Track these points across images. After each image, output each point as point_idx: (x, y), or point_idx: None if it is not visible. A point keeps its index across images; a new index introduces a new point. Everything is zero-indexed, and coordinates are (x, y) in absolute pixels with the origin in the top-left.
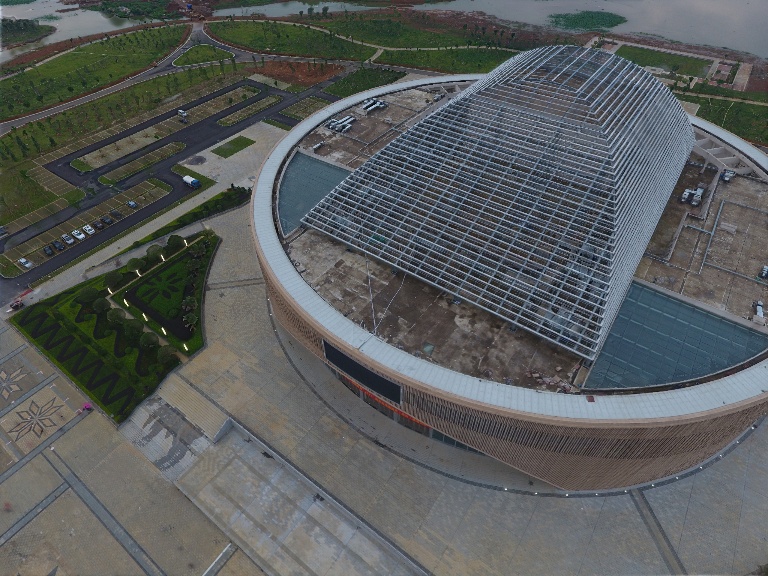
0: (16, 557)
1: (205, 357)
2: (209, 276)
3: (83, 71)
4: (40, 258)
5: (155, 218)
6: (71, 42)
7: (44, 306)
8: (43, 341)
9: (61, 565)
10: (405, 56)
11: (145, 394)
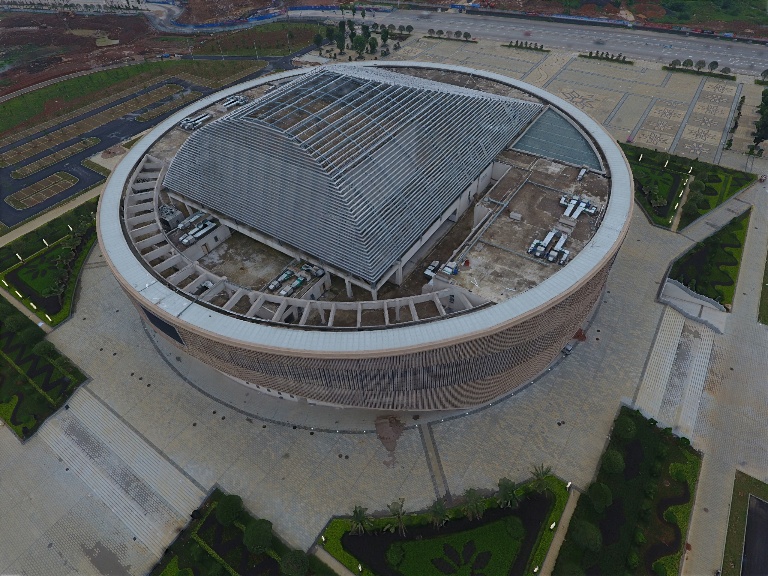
0: None
1: None
2: None
3: None
4: None
5: (767, 262)
6: None
7: (739, 177)
8: None
9: None
10: None
11: None
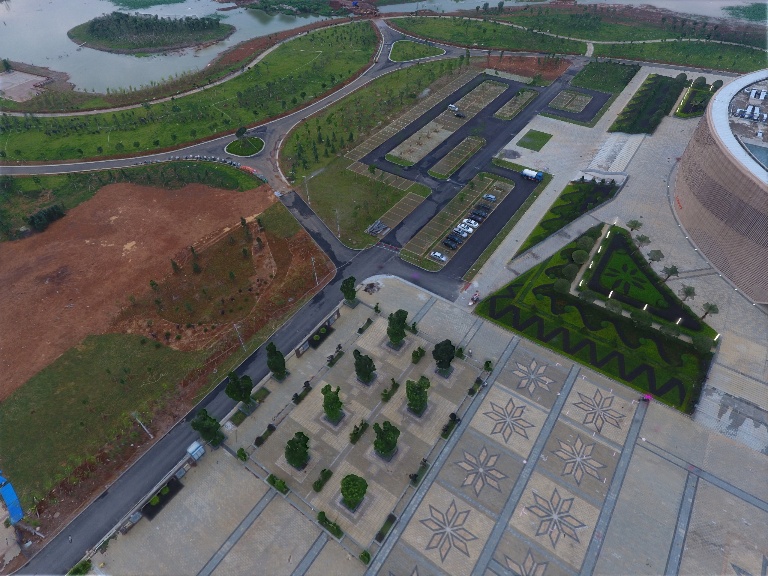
0: (712, 547)
1: (730, 347)
2: (652, 267)
3: (310, 68)
4: (446, 252)
5: (525, 211)
6: (268, 40)
7: (506, 299)
8: (534, 333)
9: (767, 554)
10: (622, 49)
11: (696, 384)
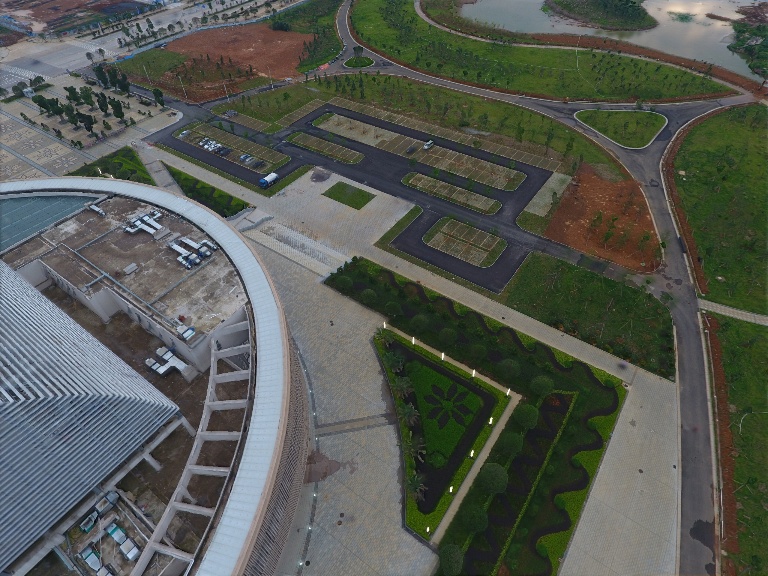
0: None
1: None
2: None
3: None
4: None
5: (219, 175)
6: (608, 44)
7: (124, 153)
8: None
9: None
10: None
11: None
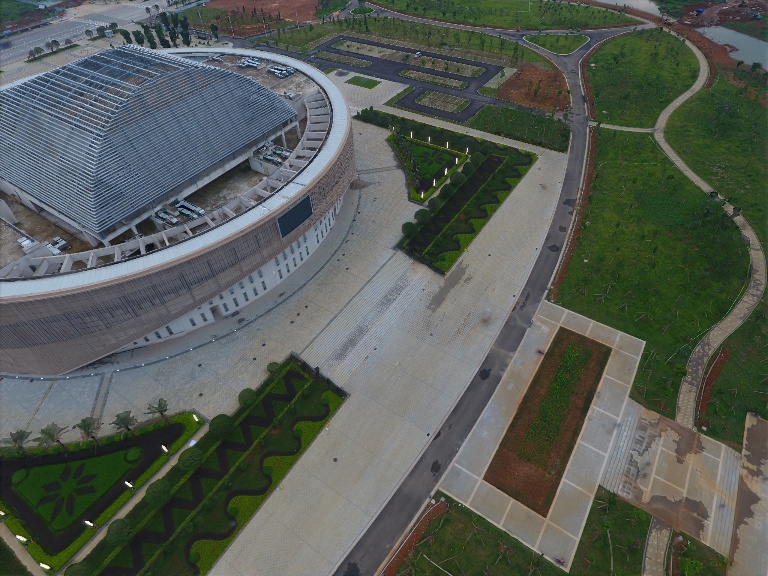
0: None
1: None
2: None
3: None
4: None
5: None
6: None
7: None
8: None
9: None
10: (630, 147)
11: None
